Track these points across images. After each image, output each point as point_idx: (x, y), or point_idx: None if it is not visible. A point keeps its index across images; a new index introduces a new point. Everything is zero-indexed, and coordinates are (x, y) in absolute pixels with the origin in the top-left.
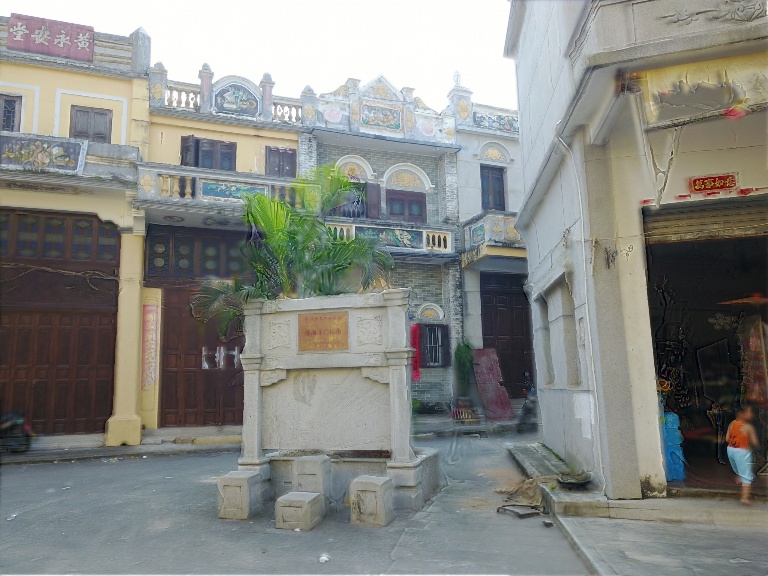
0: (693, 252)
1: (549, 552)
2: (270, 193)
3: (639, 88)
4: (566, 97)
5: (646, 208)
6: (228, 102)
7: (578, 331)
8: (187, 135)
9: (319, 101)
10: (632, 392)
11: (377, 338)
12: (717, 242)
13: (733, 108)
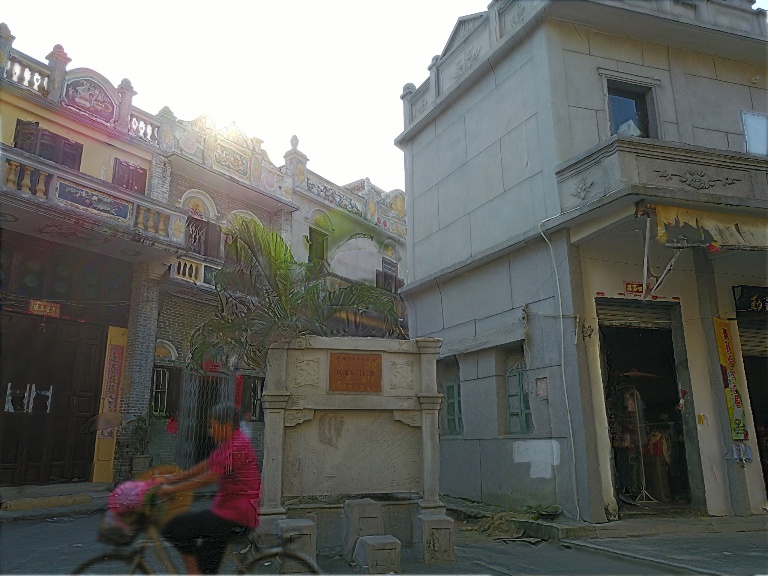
0: (618, 335)
1: (614, 564)
2: (135, 212)
3: (649, 215)
4: (535, 202)
5: (596, 298)
6: (81, 97)
7: (534, 389)
8: (26, 120)
9: (177, 126)
10: (597, 438)
11: (409, 383)
12: (631, 330)
13: (709, 244)
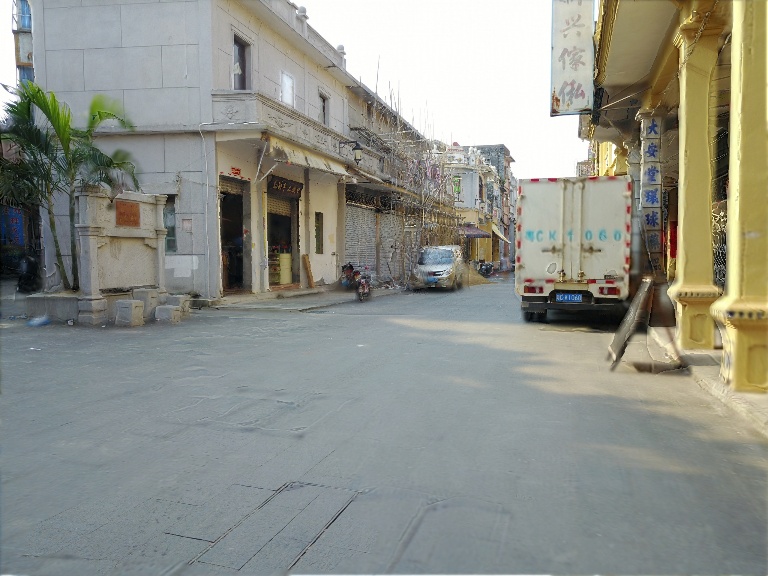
0: None
1: None
2: None
3: None
4: (192, 106)
5: (219, 175)
6: None
7: (181, 225)
8: None
9: None
10: None
11: (151, 222)
12: None
13: (287, 161)
